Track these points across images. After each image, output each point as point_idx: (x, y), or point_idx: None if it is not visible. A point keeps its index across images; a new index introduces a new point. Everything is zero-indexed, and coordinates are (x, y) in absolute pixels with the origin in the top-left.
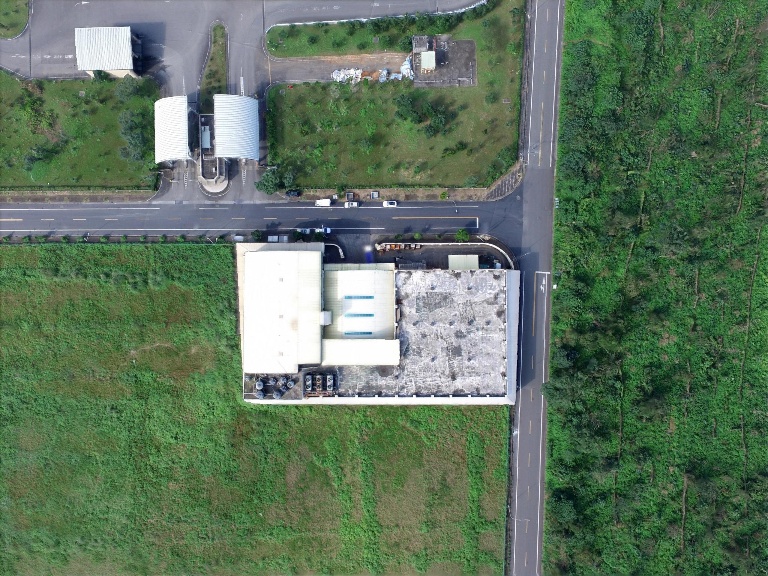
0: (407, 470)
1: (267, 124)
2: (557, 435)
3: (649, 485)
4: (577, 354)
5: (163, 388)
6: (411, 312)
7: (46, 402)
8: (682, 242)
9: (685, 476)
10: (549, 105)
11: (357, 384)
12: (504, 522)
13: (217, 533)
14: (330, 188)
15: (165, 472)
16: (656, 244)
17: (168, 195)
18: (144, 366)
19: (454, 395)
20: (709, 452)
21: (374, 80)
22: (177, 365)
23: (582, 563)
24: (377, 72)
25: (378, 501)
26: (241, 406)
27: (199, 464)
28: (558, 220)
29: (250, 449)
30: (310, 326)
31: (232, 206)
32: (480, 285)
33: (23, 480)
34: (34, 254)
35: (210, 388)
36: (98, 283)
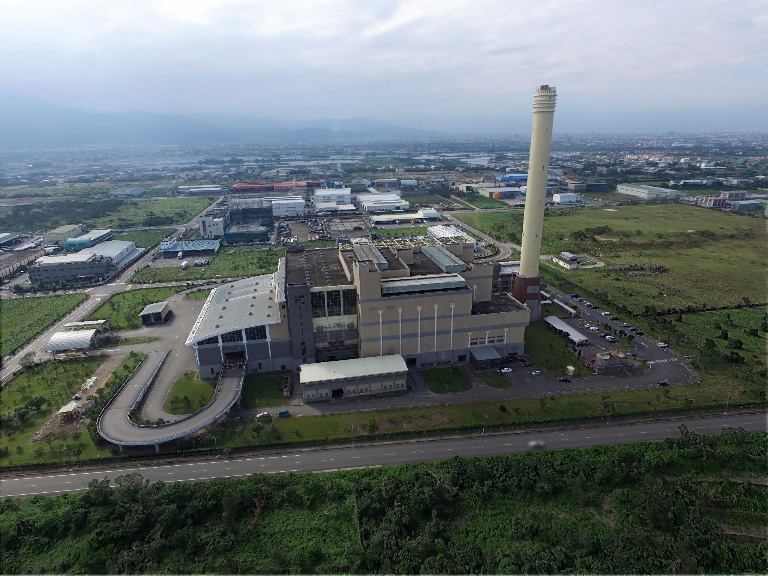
0: None
1: None
2: None
3: None
4: None
5: None
6: None
7: None
8: None
9: None
10: None
11: None
12: None
13: None
14: (5, 384)
15: None
16: None
17: None
18: None
19: None
20: None
21: None
22: None
23: None
24: None
25: None
26: None
27: None
28: None
29: None
30: None
31: None
32: None
33: None
34: None
35: None
36: None
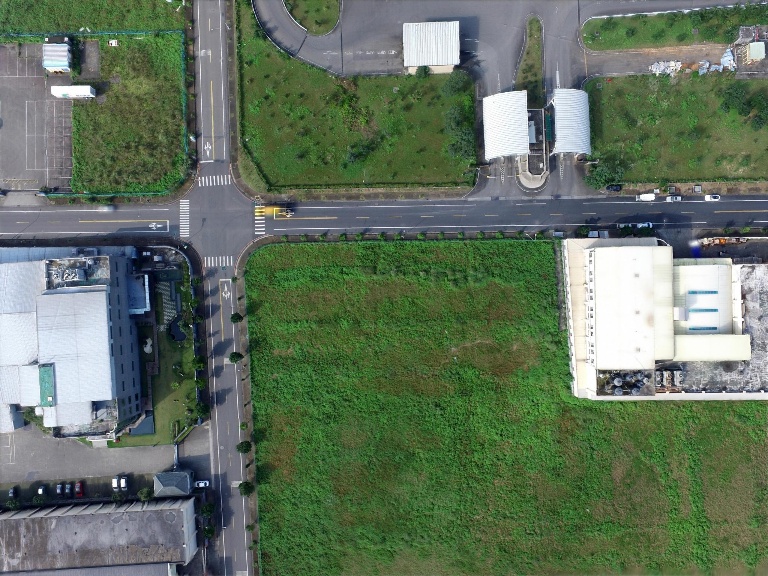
0: (734, 465)
1: None
2: None
3: None
4: None
5: (486, 385)
6: (755, 307)
7: (368, 400)
8: None
9: None
10: None
11: (701, 380)
12: None
13: (545, 529)
14: (652, 182)
15: (490, 469)
16: None
17: (484, 191)
18: (467, 363)
19: None
20: None
21: None
22: (499, 362)
23: None
24: (696, 64)
25: (706, 496)
26: (565, 402)
27: (525, 461)
28: None
29: (576, 445)
30: (665, 322)
31: (550, 202)
32: None
33: (347, 477)
34: (351, 252)
35: (533, 385)
36: (417, 280)
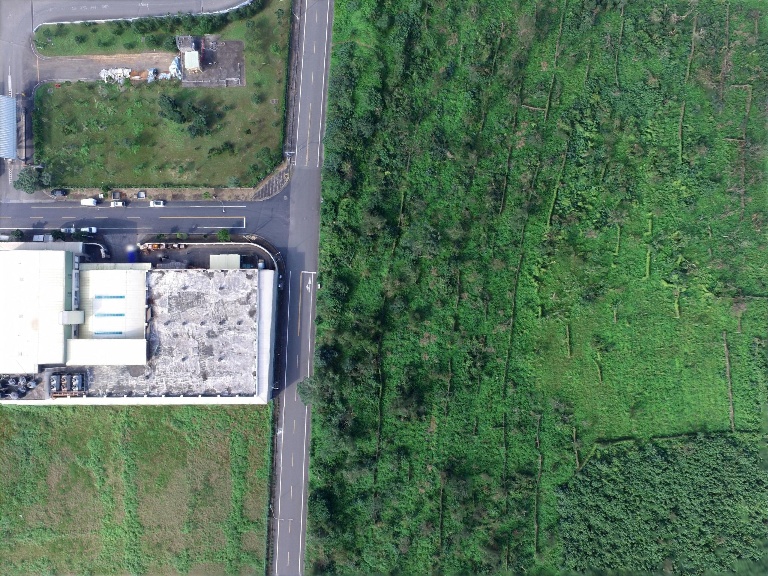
0: (170, 470)
1: (33, 123)
2: (318, 434)
3: (407, 484)
4: (334, 353)
5: None
6: (163, 312)
7: None
8: (435, 242)
9: (440, 475)
10: (317, 106)
11: (107, 384)
12: (266, 522)
13: None
14: (96, 187)
15: None
16: (407, 244)
17: None
18: None
19: (204, 395)
20: (470, 451)
21: (143, 80)
22: None
23: (341, 562)
24: (146, 72)
25: (140, 502)
26: (3, 407)
27: None
28: (321, 220)
29: (11, 450)
30: (52, 326)
31: None
32: (233, 285)
33: None
34: None
35: None
36: None
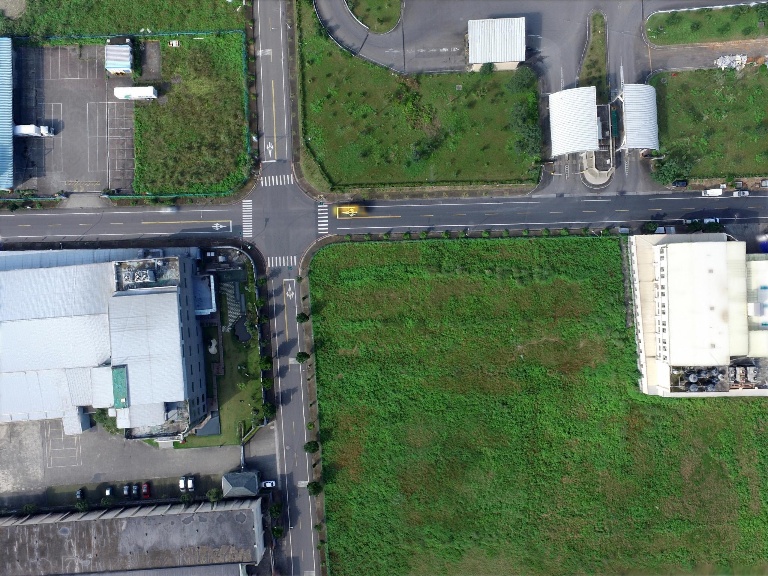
0: None
1: None
2: None
3: None
4: None
5: (553, 383)
6: None
7: (435, 399)
8: None
9: None
10: None
11: None
12: None
13: (614, 527)
14: (719, 177)
15: (558, 467)
16: None
17: (549, 188)
18: (533, 361)
19: None
20: None
21: (759, 66)
22: (566, 359)
23: None
24: (762, 58)
25: None
26: (633, 399)
27: (593, 458)
28: None
29: (644, 442)
30: (739, 317)
31: (615, 198)
32: None
33: (414, 476)
34: (415, 251)
35: (601, 382)
36: (482, 278)
